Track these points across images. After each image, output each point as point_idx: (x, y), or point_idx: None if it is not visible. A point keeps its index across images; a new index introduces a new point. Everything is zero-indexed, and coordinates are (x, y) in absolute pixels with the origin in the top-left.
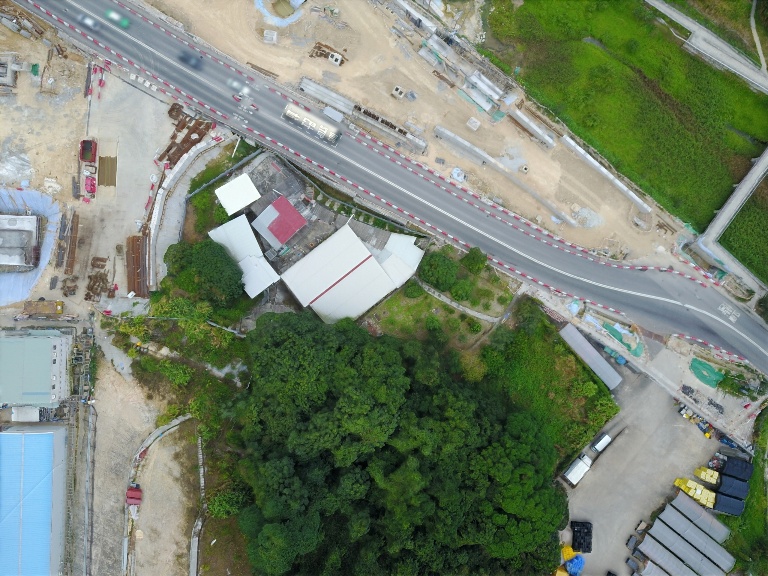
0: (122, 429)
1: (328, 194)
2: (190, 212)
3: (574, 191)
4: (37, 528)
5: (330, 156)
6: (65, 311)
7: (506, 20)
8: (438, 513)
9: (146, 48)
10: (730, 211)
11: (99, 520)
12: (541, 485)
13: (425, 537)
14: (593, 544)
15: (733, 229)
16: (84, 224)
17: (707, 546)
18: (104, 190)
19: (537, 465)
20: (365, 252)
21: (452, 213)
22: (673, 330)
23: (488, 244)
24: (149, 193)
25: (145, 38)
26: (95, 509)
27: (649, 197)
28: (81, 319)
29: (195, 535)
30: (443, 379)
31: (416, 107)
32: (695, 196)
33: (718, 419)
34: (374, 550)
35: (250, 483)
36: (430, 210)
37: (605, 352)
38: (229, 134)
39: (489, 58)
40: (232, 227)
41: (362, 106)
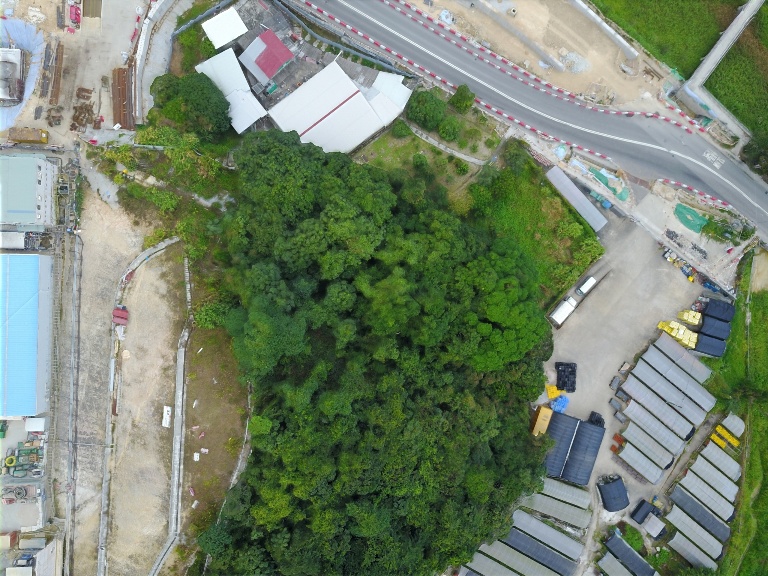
0: (108, 255)
1: (316, 34)
2: (177, 50)
3: (562, 35)
4: (23, 348)
5: None
6: (50, 141)
7: None
8: (423, 319)
9: None
10: (716, 56)
11: (85, 346)
12: (526, 298)
13: (411, 351)
14: (577, 384)
15: (719, 77)
16: (69, 55)
17: (689, 385)
18: (89, 22)
19: (522, 279)
20: (353, 87)
21: (440, 55)
22: (658, 176)
23: (476, 87)
24: (135, 25)
25: None
26: (81, 336)
27: (636, 42)
28: (66, 150)
29: (181, 346)
30: (430, 204)
31: None
32: (682, 44)
33: (701, 263)
34: (360, 364)
35: (236, 290)
36: (418, 52)
37: (591, 196)
38: None
39: None
40: (219, 61)
41: None
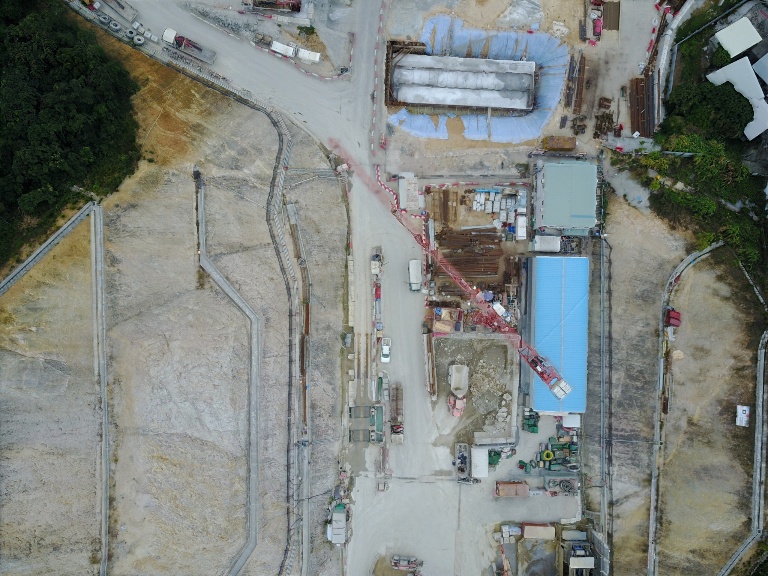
0: (646, 258)
1: None
2: (677, 59)
3: None
4: (576, 347)
5: None
6: (574, 149)
7: None
8: None
9: None
10: None
11: (620, 346)
12: None
13: None
14: None
15: None
16: (590, 66)
17: None
18: (607, 34)
19: None
20: None
21: None
22: None
23: None
24: (651, 37)
25: None
26: (614, 336)
27: None
28: (589, 157)
29: (762, 347)
30: None
31: None
32: None
33: None
34: None
35: None
36: None
37: None
38: None
39: None
40: (733, 69)
41: None
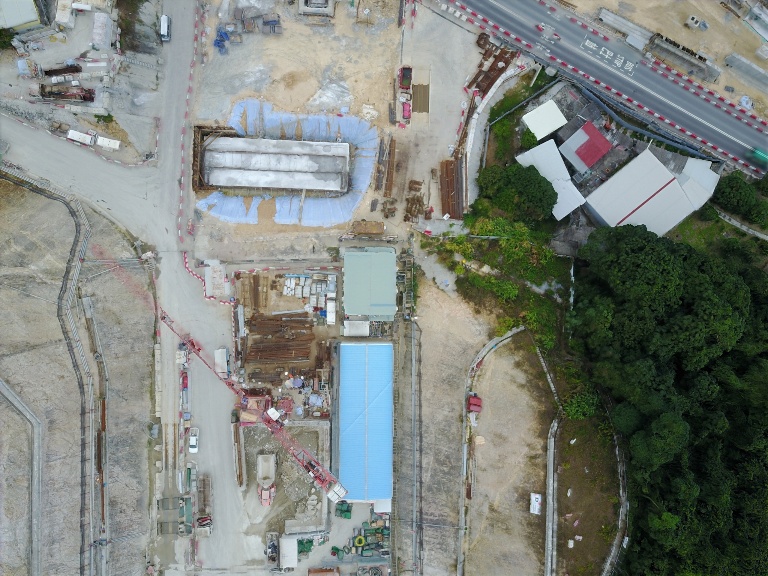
0: (452, 342)
1: None
2: (491, 139)
3: None
4: (380, 435)
5: (627, 84)
6: (385, 232)
7: None
8: None
9: None
10: None
11: (429, 430)
12: None
13: (767, 438)
14: None
15: None
16: (400, 149)
17: None
18: (417, 117)
19: None
20: (669, 175)
21: (741, 140)
22: None
23: None
24: (460, 119)
25: None
26: (424, 420)
27: None
28: (400, 240)
29: (552, 436)
30: None
31: (708, 37)
32: None
33: None
34: (719, 451)
35: (612, 383)
36: (720, 137)
37: None
38: (532, 63)
39: None
40: (540, 152)
41: None
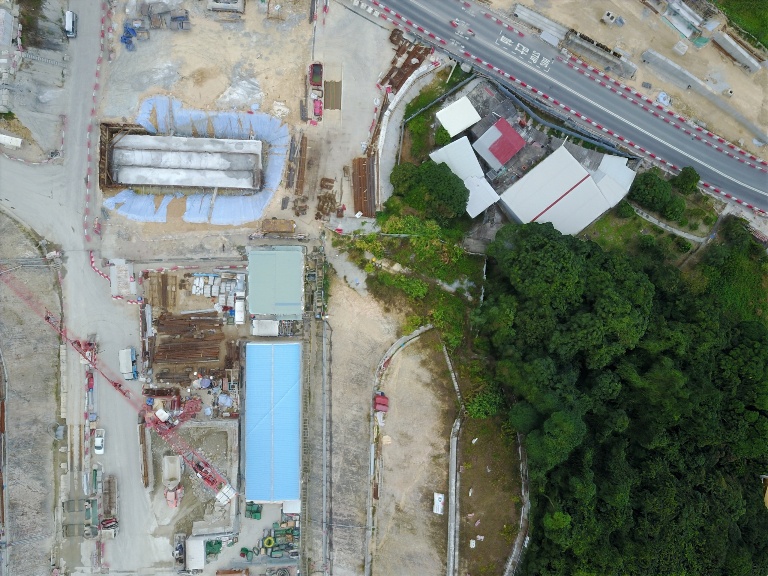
0: (361, 341)
1: None
2: (406, 137)
3: None
4: (287, 435)
5: (543, 80)
6: (296, 230)
7: None
8: (696, 409)
9: None
10: None
11: (339, 430)
12: None
13: (672, 436)
14: None
15: None
16: (312, 146)
17: None
18: (329, 114)
19: None
20: (583, 172)
21: (659, 136)
22: None
23: (693, 166)
24: (373, 116)
25: None
26: (334, 419)
27: None
28: (312, 238)
29: (454, 435)
30: None
31: (624, 32)
32: None
33: None
34: (623, 449)
35: (513, 382)
36: (638, 133)
37: None
38: (446, 59)
39: None
40: (454, 149)
41: None
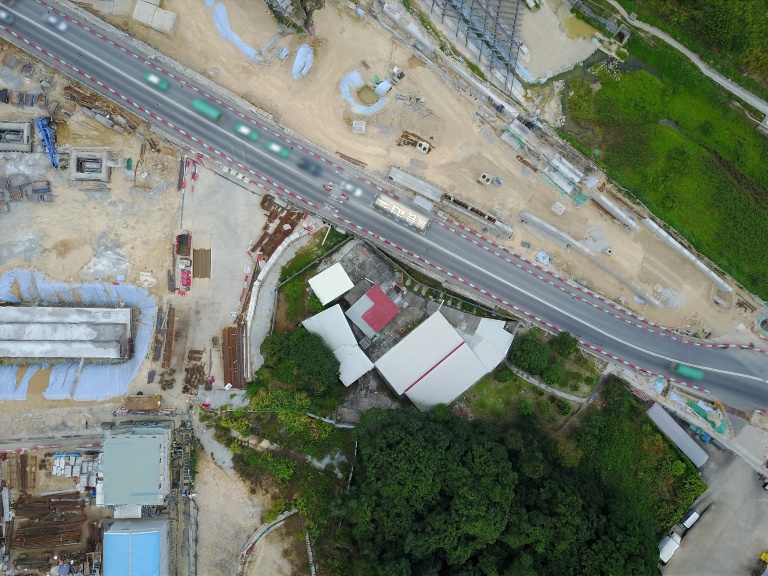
0: (226, 524)
1: (417, 279)
2: (281, 300)
3: (656, 272)
4: None
5: (419, 243)
6: (163, 405)
7: (585, 104)
8: None
9: (237, 140)
10: None
11: None
12: None
13: None
14: None
15: None
16: (180, 317)
17: None
18: (199, 282)
19: (645, 557)
20: (458, 339)
21: (538, 296)
22: (755, 406)
23: (574, 325)
24: (243, 284)
25: (236, 131)
26: None
27: (729, 276)
28: (179, 412)
29: None
30: (545, 469)
31: (502, 193)
32: None
33: None
34: None
35: None
36: (517, 293)
37: (690, 429)
38: (320, 223)
39: (570, 142)
40: (326, 317)
41: (449, 193)
